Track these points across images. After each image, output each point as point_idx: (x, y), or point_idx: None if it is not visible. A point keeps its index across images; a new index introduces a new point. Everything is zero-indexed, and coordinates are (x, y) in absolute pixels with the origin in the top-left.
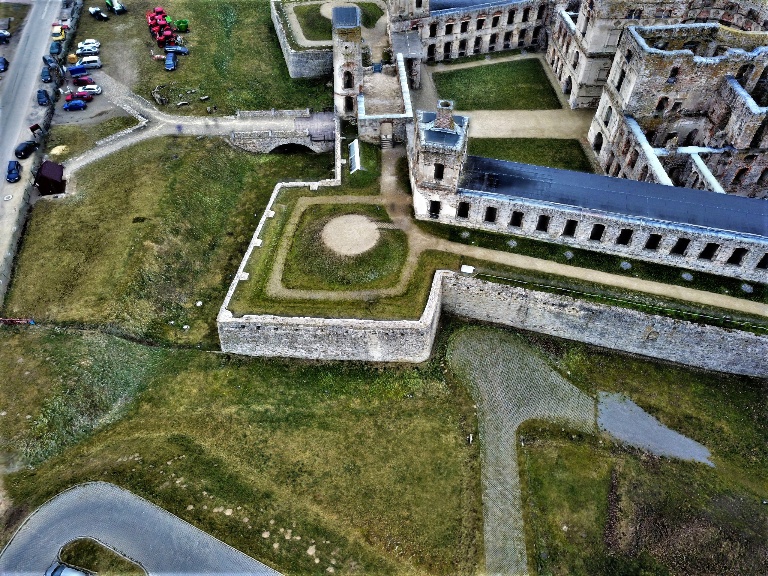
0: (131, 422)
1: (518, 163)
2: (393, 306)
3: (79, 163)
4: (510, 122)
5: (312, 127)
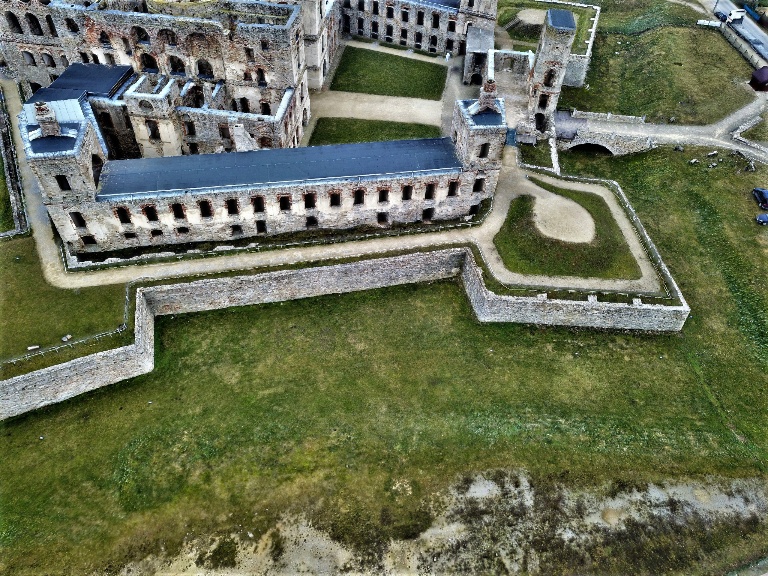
0: (627, 17)
1: (427, 1)
2: (509, 2)
3: (759, 103)
4: (381, 109)
5: (571, 124)
